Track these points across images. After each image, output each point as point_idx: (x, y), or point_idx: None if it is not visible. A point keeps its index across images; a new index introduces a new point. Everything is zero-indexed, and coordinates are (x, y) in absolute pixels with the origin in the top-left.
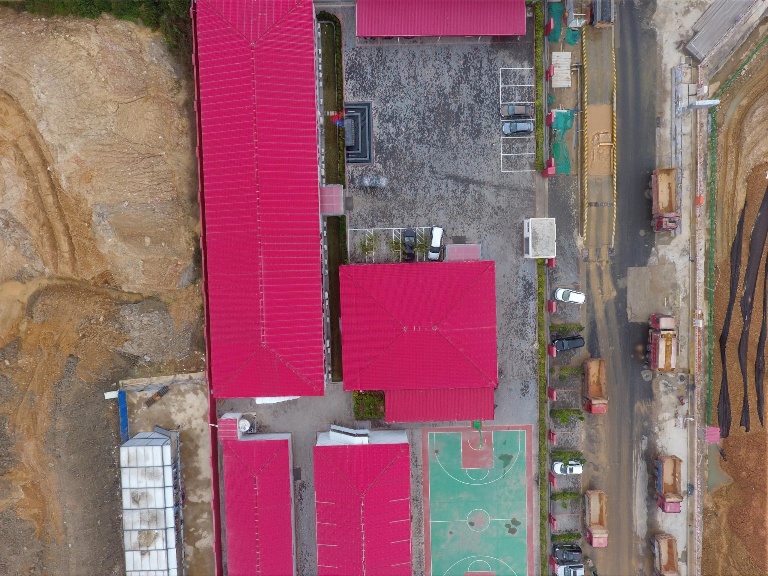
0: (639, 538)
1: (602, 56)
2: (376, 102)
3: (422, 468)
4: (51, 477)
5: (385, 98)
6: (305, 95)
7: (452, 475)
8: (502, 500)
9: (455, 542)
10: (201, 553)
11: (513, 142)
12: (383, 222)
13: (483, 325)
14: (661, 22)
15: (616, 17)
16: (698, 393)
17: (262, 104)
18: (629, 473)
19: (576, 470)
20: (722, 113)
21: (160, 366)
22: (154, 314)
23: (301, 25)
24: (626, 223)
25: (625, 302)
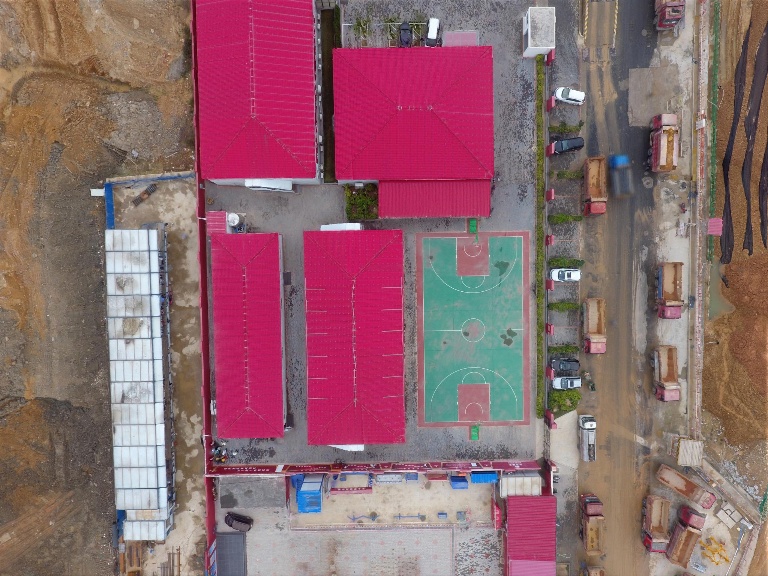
0: (638, 353)
1: None
2: None
3: (416, 275)
4: (34, 268)
5: None
6: None
7: (447, 283)
8: (498, 309)
9: (449, 353)
10: (188, 360)
11: None
12: (378, 17)
13: (480, 111)
14: None
15: None
16: (700, 198)
17: None
18: (628, 285)
19: (574, 275)
20: None
21: (148, 164)
22: (142, 103)
23: None
24: (628, 22)
25: (626, 105)
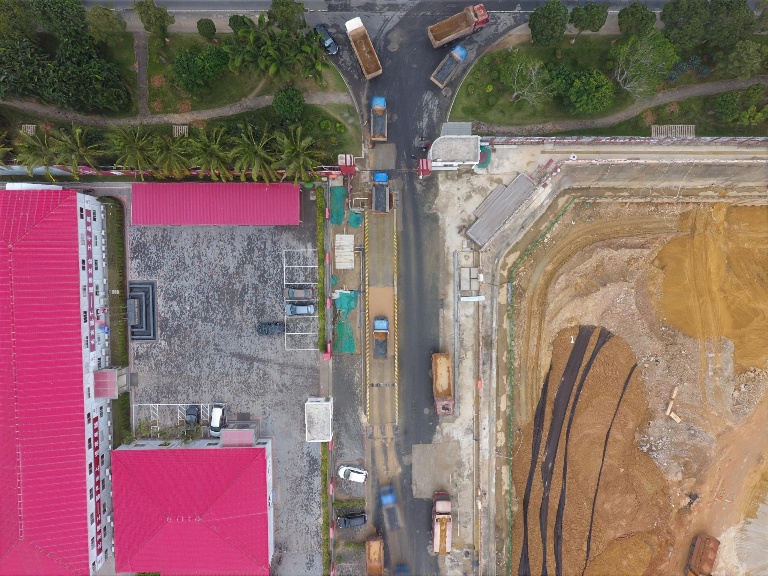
0: None
1: (384, 240)
2: (161, 281)
3: None
4: None
5: (170, 277)
6: (68, 291)
7: None
8: None
9: None
10: None
11: (297, 321)
12: (168, 398)
13: (252, 512)
14: (443, 206)
15: (398, 201)
16: (480, 571)
17: (21, 304)
18: None
19: None
20: (527, 278)
21: None
22: None
23: (64, 223)
24: (410, 401)
25: (410, 478)
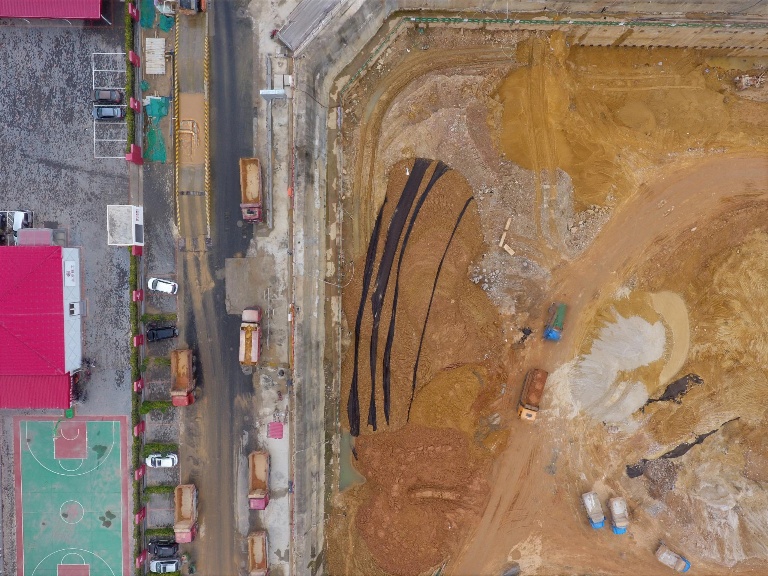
0: (241, 535)
1: (194, 43)
2: None
3: (14, 457)
4: None
5: None
6: None
7: (45, 465)
8: (96, 492)
9: (48, 534)
10: None
11: (106, 128)
12: None
13: (47, 311)
14: (257, 11)
15: (211, 5)
16: (293, 388)
17: None
18: (230, 468)
19: (164, 463)
20: (361, 107)
21: None
22: None
23: None
24: (223, 213)
25: (223, 294)
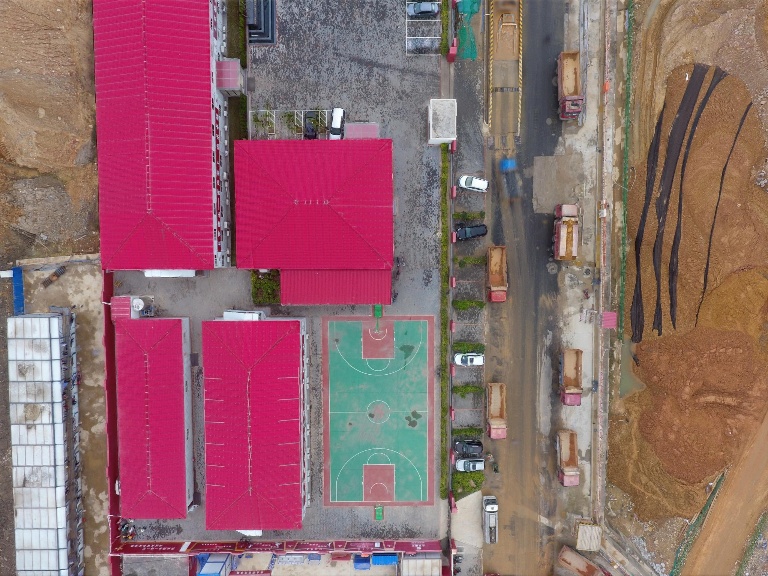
0: (542, 435)
1: None
2: None
3: (322, 357)
4: None
5: None
6: None
7: (352, 365)
8: (403, 392)
9: (354, 434)
10: (97, 438)
11: (418, 25)
12: (285, 104)
13: (378, 204)
14: None
15: None
16: (603, 286)
17: None
18: (533, 368)
19: (476, 361)
20: (642, 12)
21: (57, 246)
22: (49, 189)
23: None
24: (533, 111)
25: (531, 192)
